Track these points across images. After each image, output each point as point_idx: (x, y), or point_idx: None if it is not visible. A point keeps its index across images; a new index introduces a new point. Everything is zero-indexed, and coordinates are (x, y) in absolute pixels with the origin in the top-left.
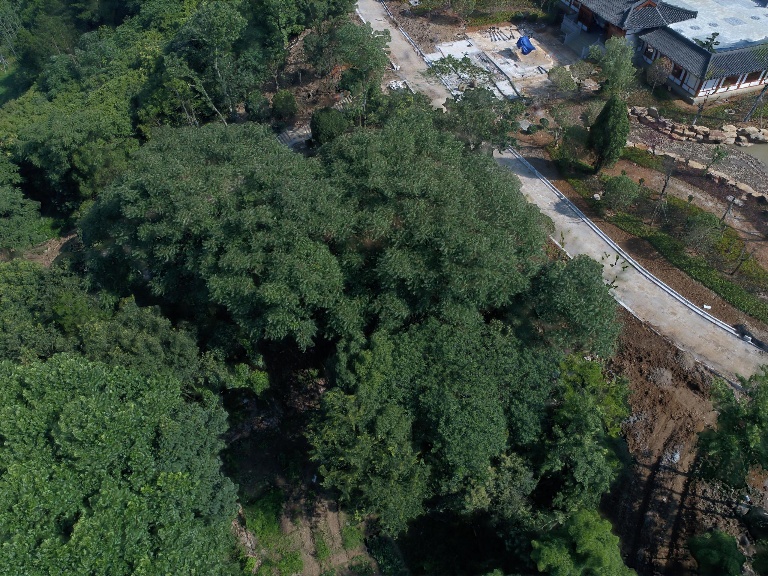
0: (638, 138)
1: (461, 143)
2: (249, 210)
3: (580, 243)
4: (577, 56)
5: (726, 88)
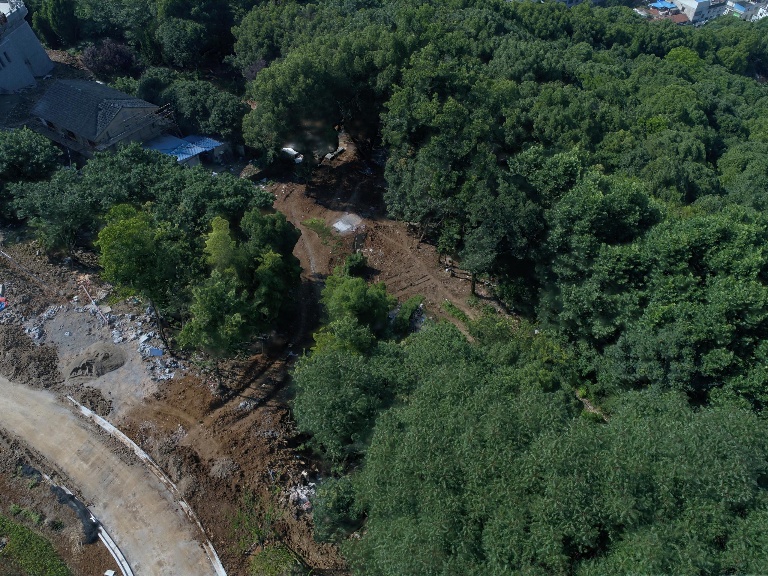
0: None
1: None
2: (762, 431)
3: None
4: None
5: None
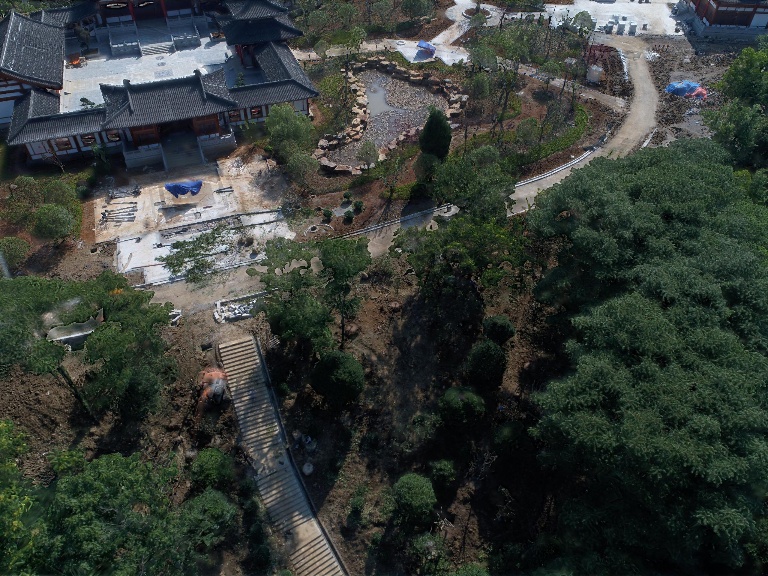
0: None
1: (598, 166)
2: None
3: (520, 200)
4: (199, 165)
5: None
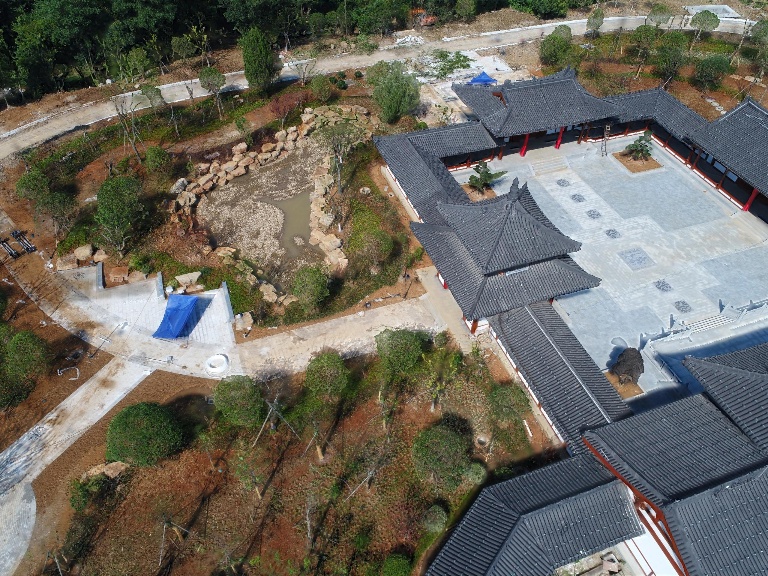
0: None
1: None
2: None
3: (193, 89)
4: None
5: None
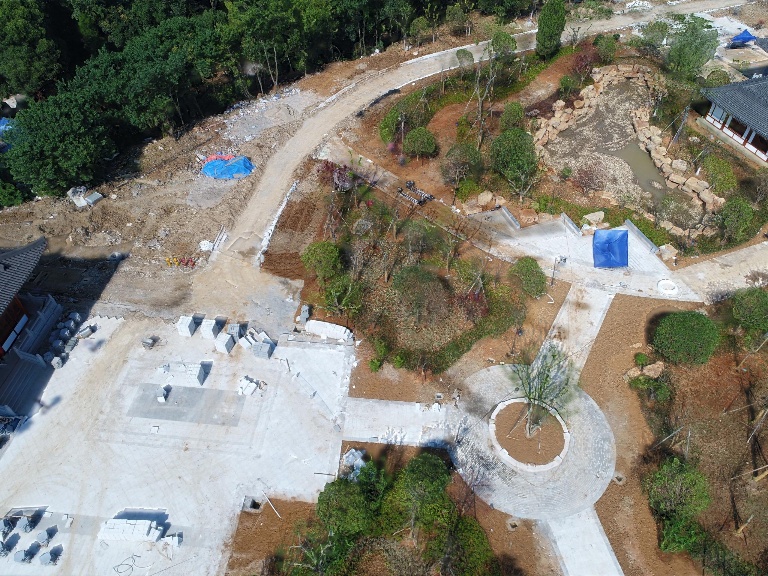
0: (623, 95)
1: None
2: None
3: None
4: None
5: (733, 134)
